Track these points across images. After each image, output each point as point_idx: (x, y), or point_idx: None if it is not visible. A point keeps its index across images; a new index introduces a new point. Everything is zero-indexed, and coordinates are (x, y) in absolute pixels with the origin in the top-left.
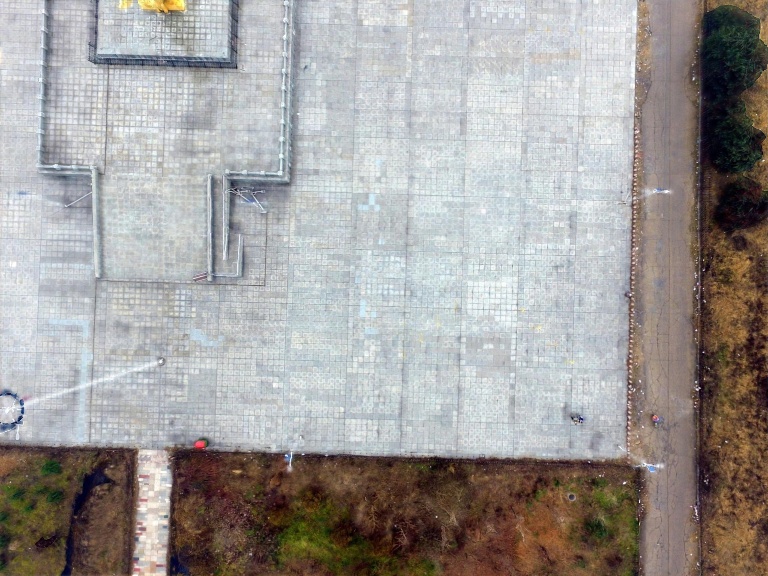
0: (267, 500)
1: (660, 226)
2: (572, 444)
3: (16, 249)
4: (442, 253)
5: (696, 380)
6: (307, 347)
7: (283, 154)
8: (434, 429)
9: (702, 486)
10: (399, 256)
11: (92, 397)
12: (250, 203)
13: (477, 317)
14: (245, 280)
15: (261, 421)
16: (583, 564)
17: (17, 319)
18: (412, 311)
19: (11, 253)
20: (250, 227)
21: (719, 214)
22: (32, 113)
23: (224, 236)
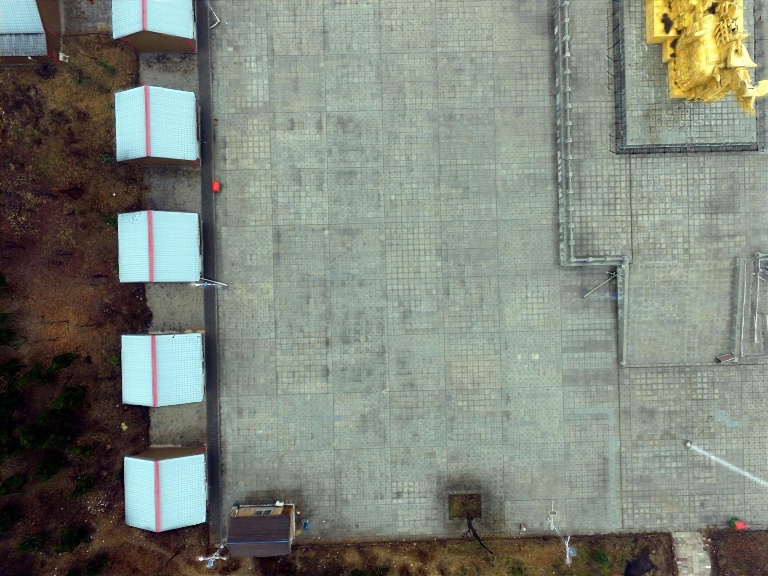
0: None
1: None
2: None
3: (537, 341)
4: None
5: None
6: None
7: None
8: None
9: None
10: None
11: (622, 483)
12: (765, 282)
13: None
14: (765, 359)
15: None
16: None
17: (543, 411)
18: None
19: (533, 345)
20: (767, 306)
21: None
22: (545, 205)
23: None
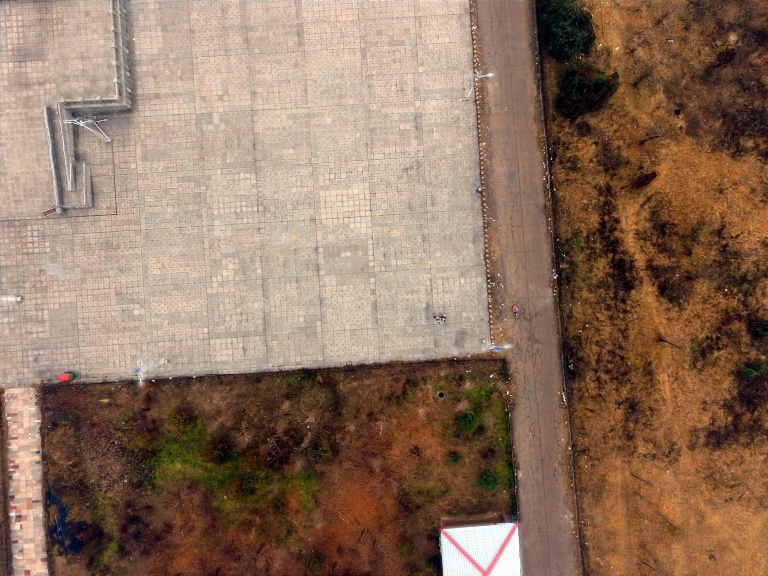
0: (137, 426)
1: (505, 119)
2: (437, 343)
3: None
4: (291, 166)
5: (553, 268)
6: (165, 271)
7: (118, 78)
8: (299, 341)
9: (567, 371)
10: (249, 173)
11: None
12: (94, 133)
13: (332, 226)
14: (96, 210)
15: (126, 349)
16: (454, 458)
17: None
18: (267, 226)
19: None
20: (96, 157)
21: (559, 100)
22: None
23: (67, 166)
